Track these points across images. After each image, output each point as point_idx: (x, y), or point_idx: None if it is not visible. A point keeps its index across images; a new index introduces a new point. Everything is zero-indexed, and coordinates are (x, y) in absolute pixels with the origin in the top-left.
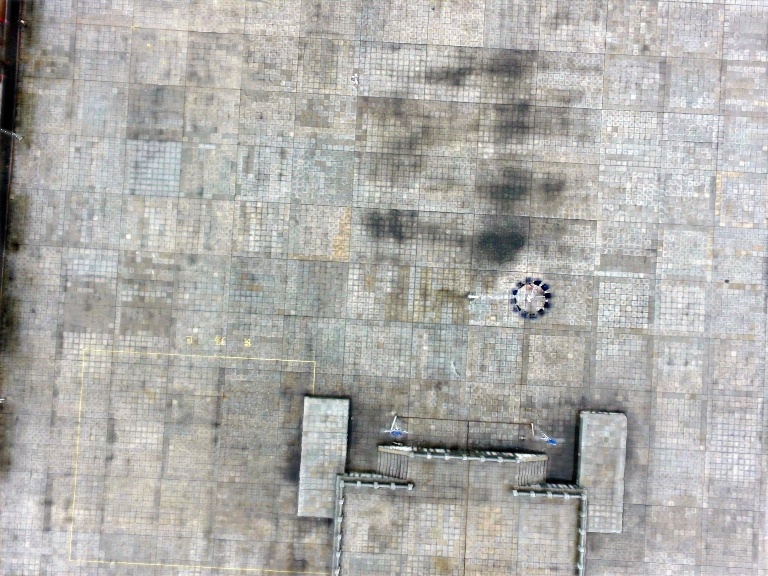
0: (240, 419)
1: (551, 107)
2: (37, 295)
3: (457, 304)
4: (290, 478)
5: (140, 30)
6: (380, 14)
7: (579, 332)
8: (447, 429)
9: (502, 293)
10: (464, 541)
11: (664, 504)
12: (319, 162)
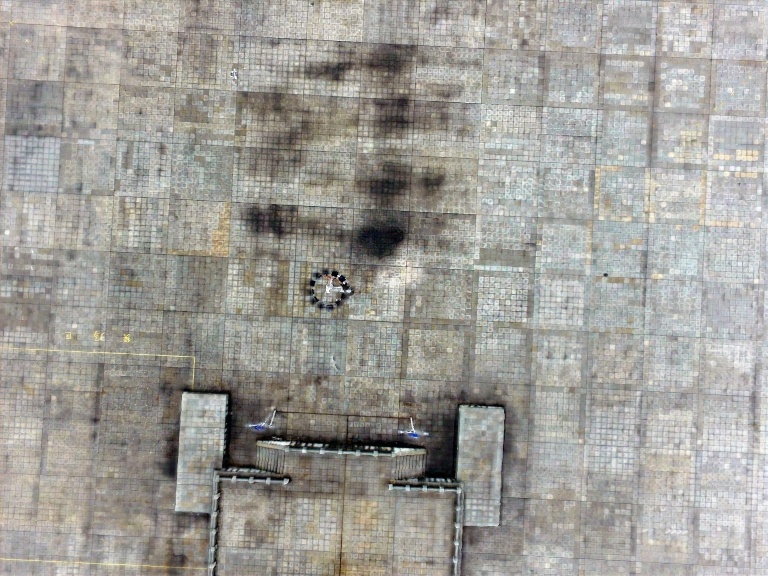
0: (119, 415)
1: (430, 102)
2: None
3: None
4: (169, 473)
5: (18, 26)
6: (259, 9)
7: (458, 326)
8: (326, 424)
9: (382, 287)
10: (340, 535)
11: (543, 497)
12: (198, 157)
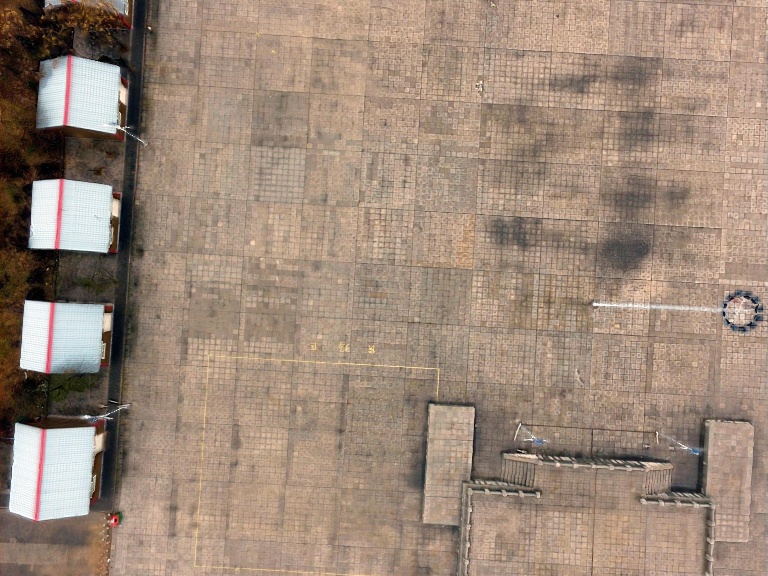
0: (364, 426)
1: (676, 115)
2: (162, 301)
3: (581, 312)
4: (414, 485)
5: (265, 36)
6: (504, 21)
7: (704, 340)
8: (571, 437)
9: (626, 301)
10: (591, 549)
11: None
12: (443, 169)
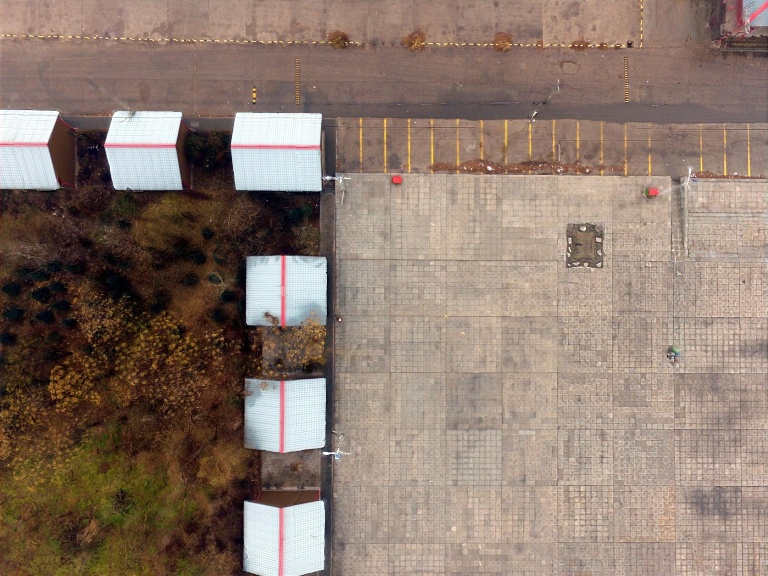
0: None
1: None
2: None
3: None
4: None
5: (454, 318)
6: (691, 289)
7: None
8: None
9: None
10: None
11: None
12: (640, 442)
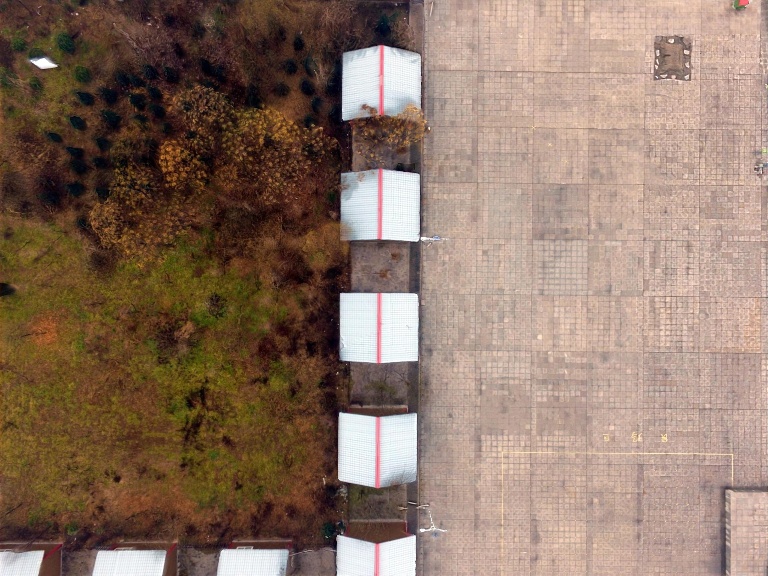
0: (661, 515)
1: None
2: (453, 400)
3: None
4: (715, 572)
5: (541, 130)
6: None
7: None
8: None
9: None
10: None
11: None
12: (726, 254)
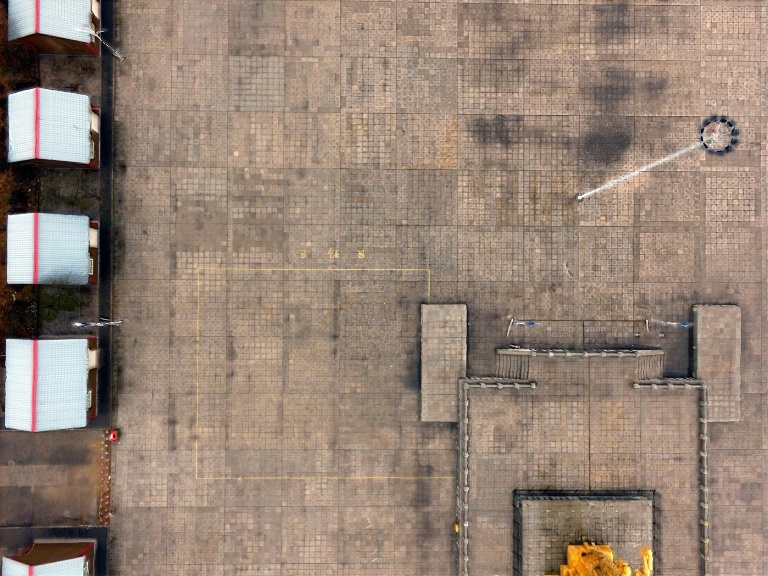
0: (358, 330)
1: (650, 6)
2: (148, 216)
3: (567, 206)
4: (411, 386)
5: None
6: None
7: (688, 228)
8: (563, 330)
9: (610, 193)
10: (588, 436)
11: None
12: (423, 71)
